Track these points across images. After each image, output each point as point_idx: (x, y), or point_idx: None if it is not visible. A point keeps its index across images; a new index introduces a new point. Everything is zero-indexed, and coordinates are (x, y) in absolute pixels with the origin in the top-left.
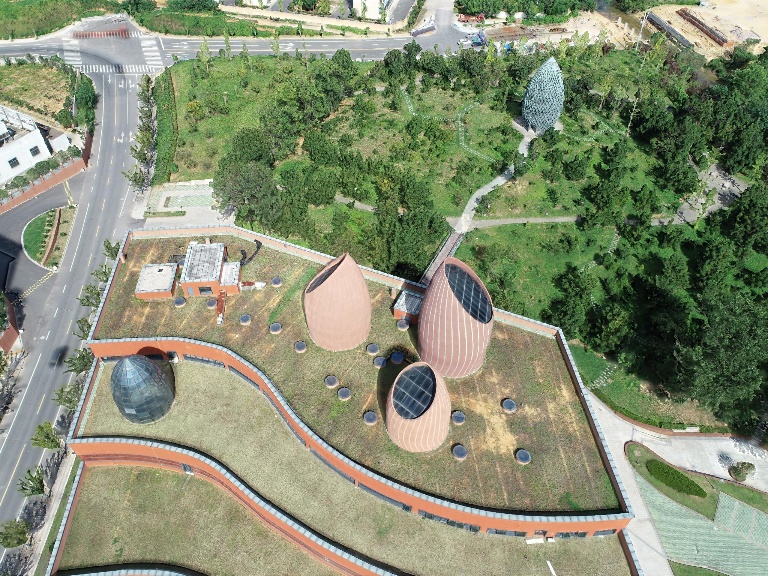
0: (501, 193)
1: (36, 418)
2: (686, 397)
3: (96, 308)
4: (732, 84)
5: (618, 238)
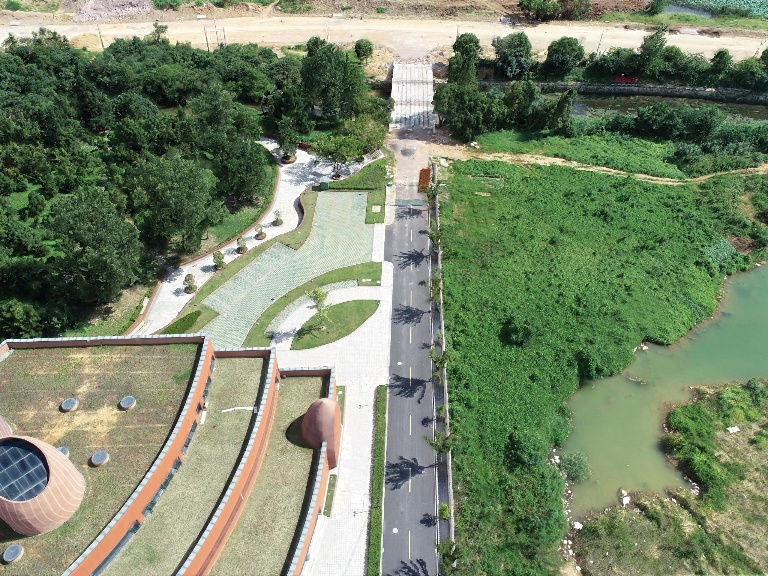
0: None
1: None
2: (118, 291)
3: None
4: None
5: None
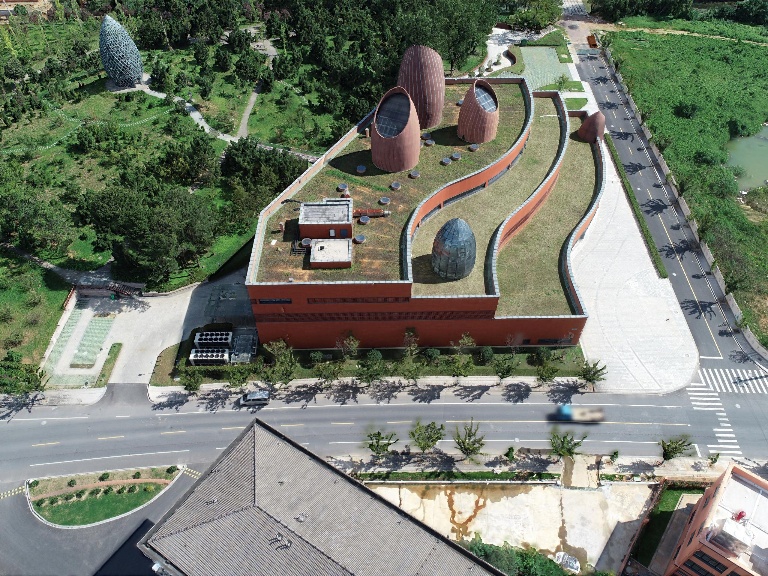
0: (212, 116)
1: (416, 421)
2: None
3: (290, 377)
4: (97, 14)
5: (283, 82)
